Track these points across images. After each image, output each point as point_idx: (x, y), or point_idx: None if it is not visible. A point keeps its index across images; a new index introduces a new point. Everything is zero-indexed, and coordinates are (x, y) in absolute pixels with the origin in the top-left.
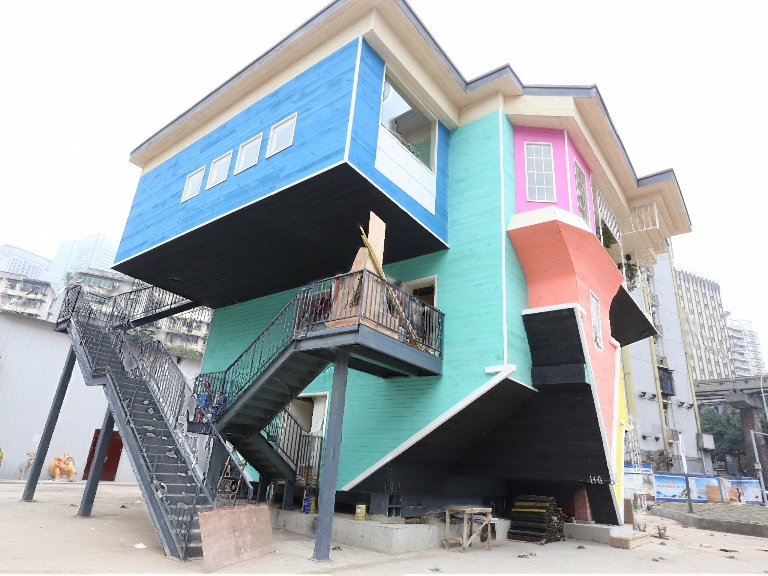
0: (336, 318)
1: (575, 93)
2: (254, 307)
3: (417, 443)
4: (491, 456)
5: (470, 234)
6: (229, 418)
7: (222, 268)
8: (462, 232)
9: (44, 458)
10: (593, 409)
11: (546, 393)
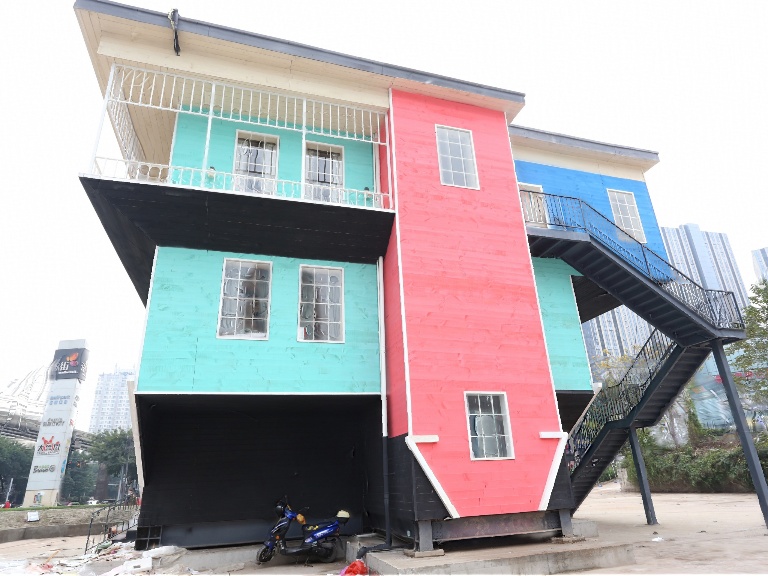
0: None
1: None
2: None
3: None
4: None
5: None
6: None
7: None
8: None
9: (755, 485)
10: None
11: None
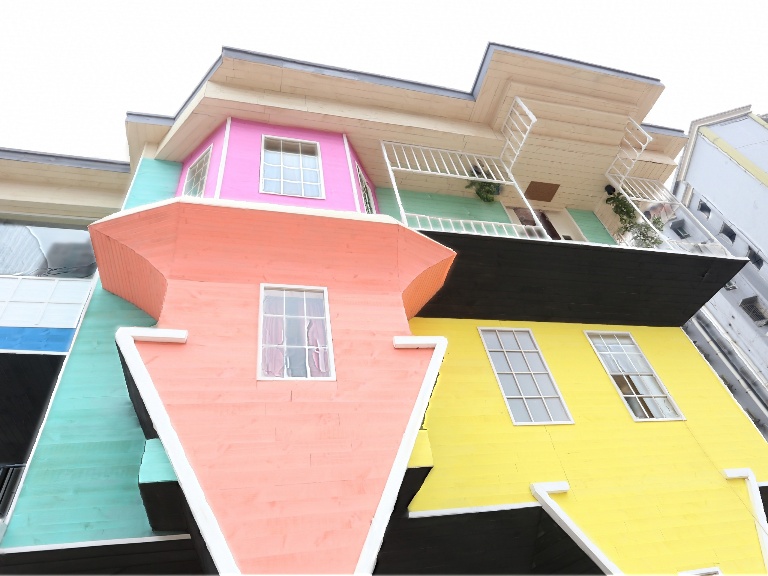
0: None
1: None
2: None
3: None
4: None
5: None
6: None
7: None
8: None
9: None
10: None
11: None
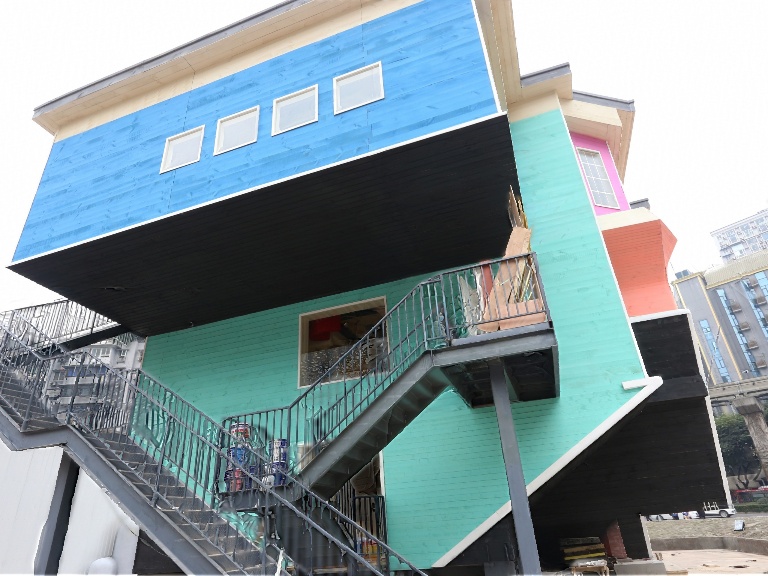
0: (503, 317)
1: (617, 105)
2: (224, 330)
3: (540, 487)
4: (579, 495)
5: (556, 234)
6: (318, 478)
7: (207, 271)
8: (544, 232)
9: None
10: (708, 425)
11: (651, 412)
